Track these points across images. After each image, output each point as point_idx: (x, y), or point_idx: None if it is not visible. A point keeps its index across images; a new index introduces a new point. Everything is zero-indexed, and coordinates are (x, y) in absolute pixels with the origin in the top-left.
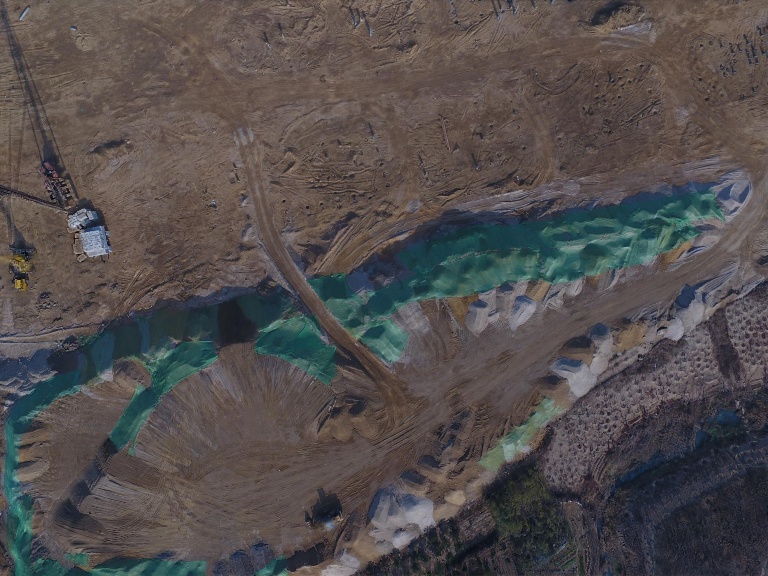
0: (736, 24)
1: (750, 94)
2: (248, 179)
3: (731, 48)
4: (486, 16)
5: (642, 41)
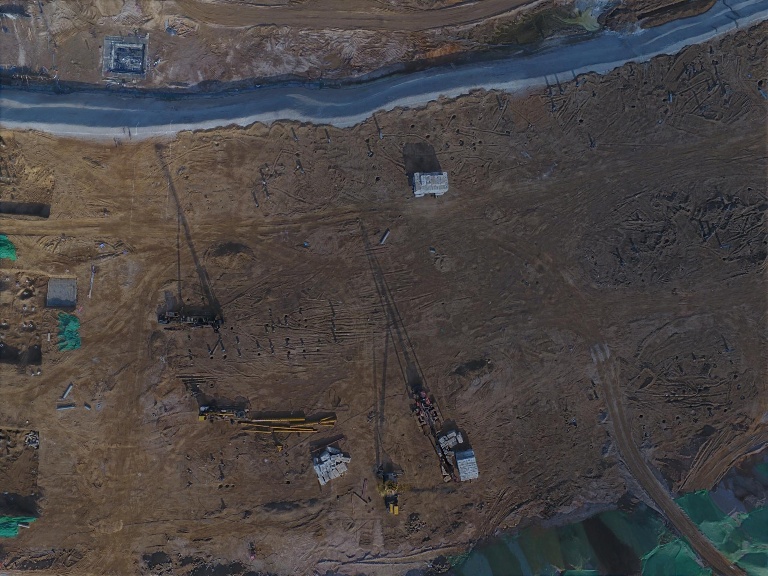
0: None
1: None
2: (606, 395)
3: None
4: None
5: None
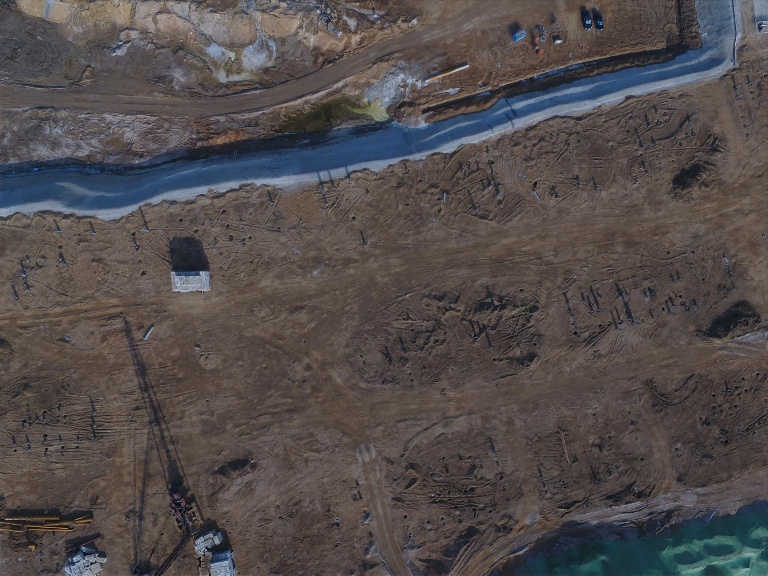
0: None
1: None
2: (370, 496)
3: None
4: (605, 327)
5: (758, 350)
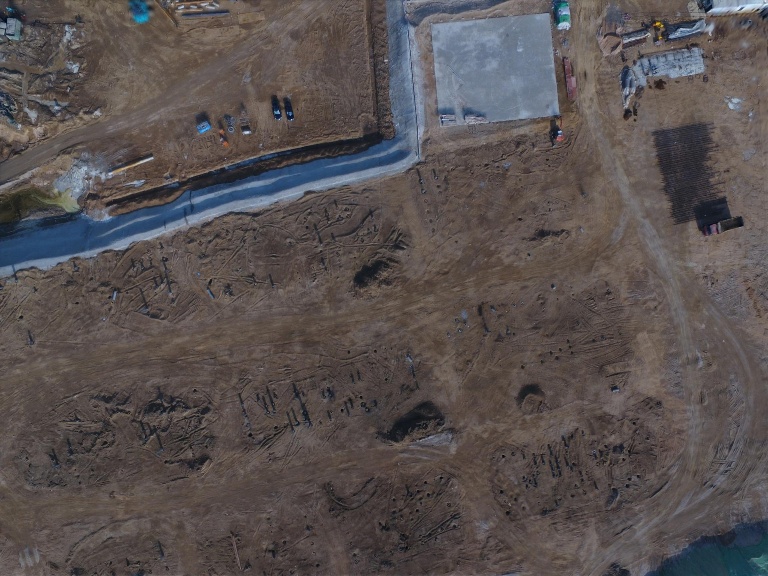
0: (540, 433)
1: (553, 507)
2: None
3: (534, 459)
4: (281, 429)
5: (442, 453)
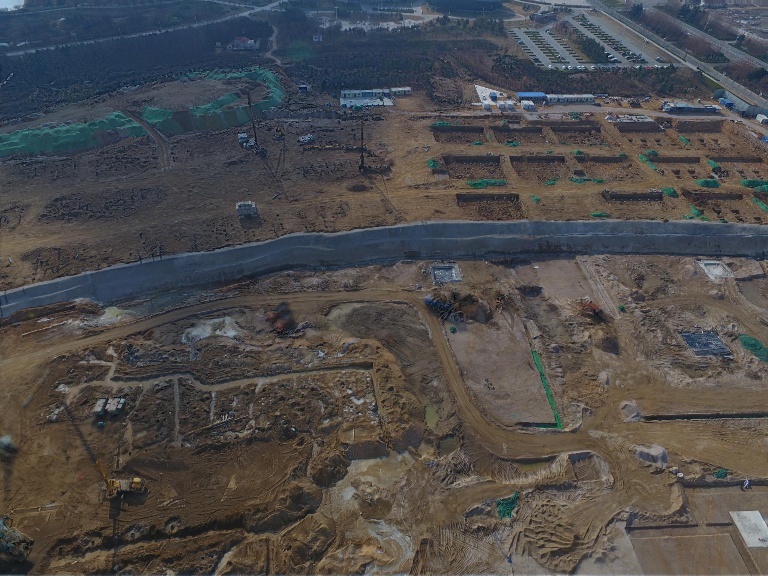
0: None
1: None
2: None
3: None
4: (2, 212)
5: None
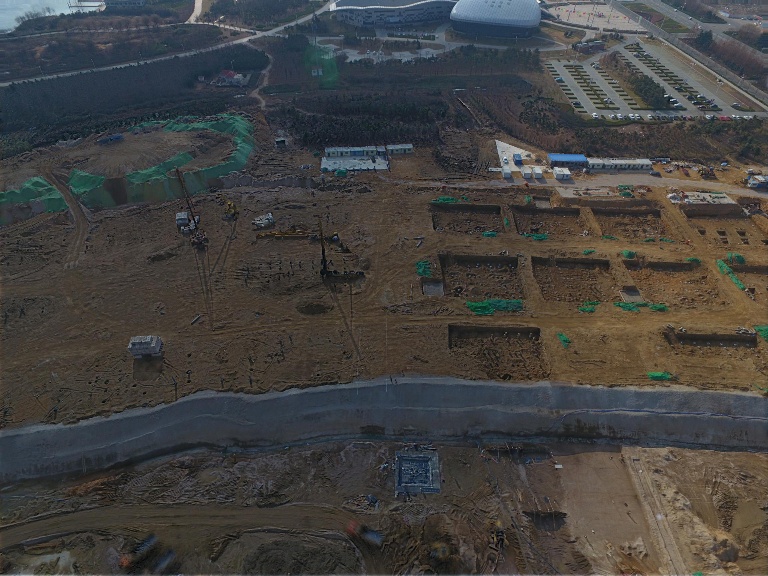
0: None
1: None
2: None
3: None
4: None
5: None
